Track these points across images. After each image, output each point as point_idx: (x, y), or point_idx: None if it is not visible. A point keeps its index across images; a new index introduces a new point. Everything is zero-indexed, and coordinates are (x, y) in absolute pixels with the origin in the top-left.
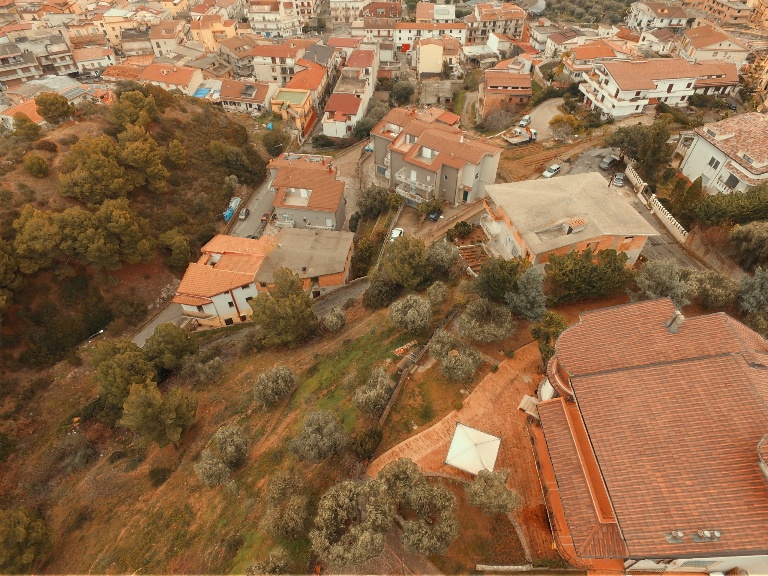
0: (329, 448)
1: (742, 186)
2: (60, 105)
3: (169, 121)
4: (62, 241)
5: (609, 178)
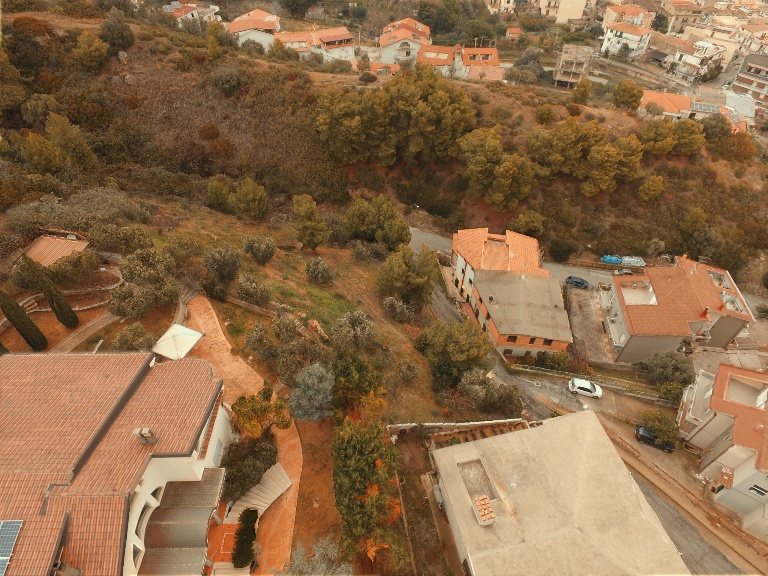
0: (208, 261)
1: None
2: (629, 95)
3: (703, 169)
4: (471, 152)
5: None
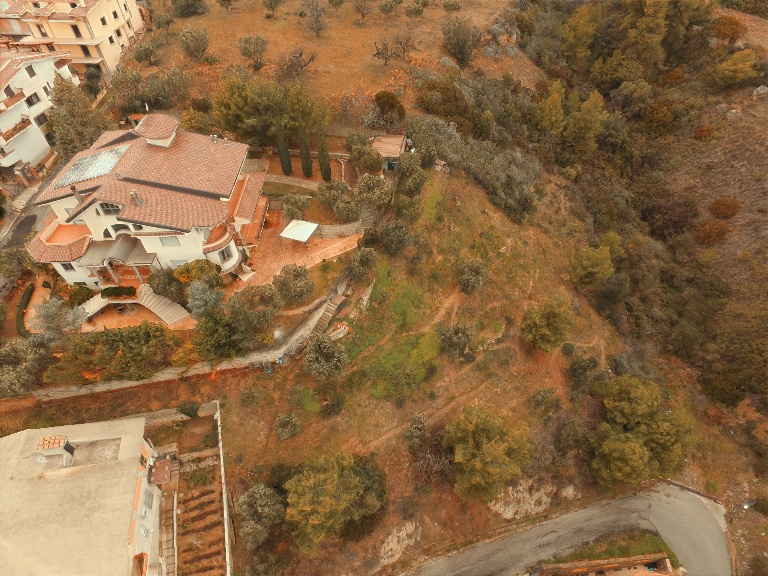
0: None
1: None
2: None
3: None
4: None
5: None
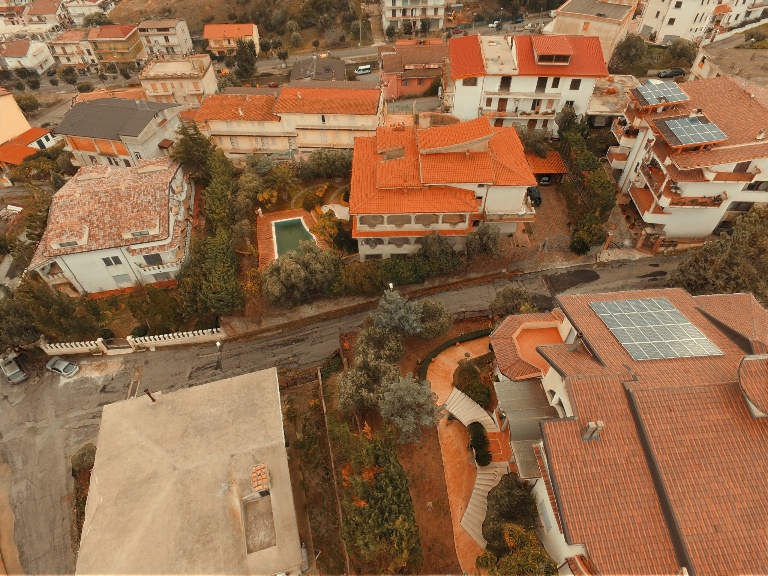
0: None
1: (167, 254)
2: None
3: None
4: None
5: (50, 379)
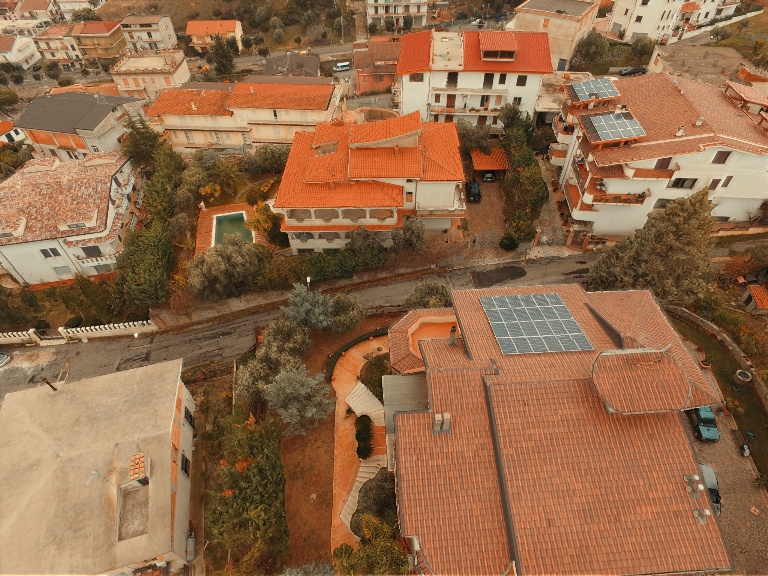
0: None
1: (106, 246)
2: None
3: None
4: None
5: None
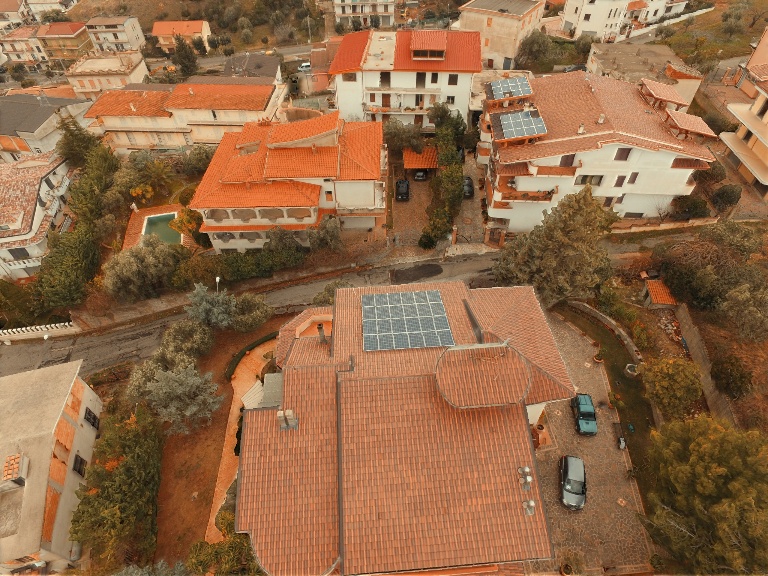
0: None
1: (33, 248)
2: None
3: None
4: None
5: None
